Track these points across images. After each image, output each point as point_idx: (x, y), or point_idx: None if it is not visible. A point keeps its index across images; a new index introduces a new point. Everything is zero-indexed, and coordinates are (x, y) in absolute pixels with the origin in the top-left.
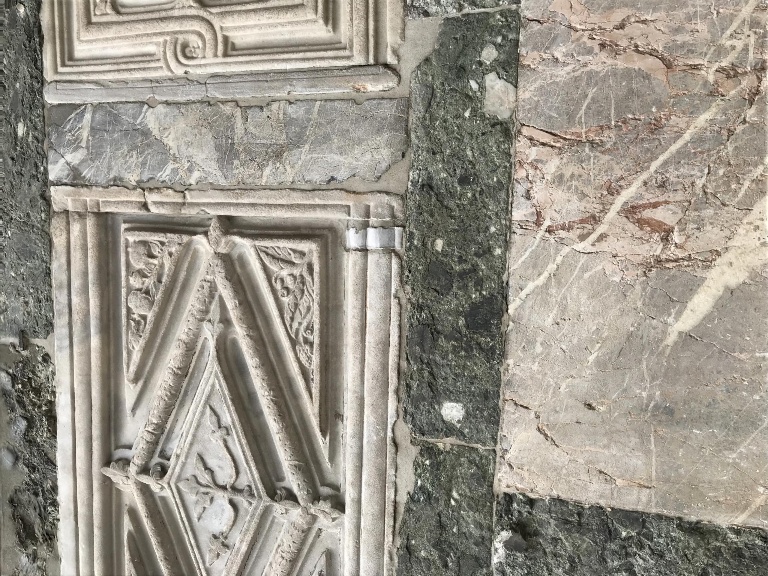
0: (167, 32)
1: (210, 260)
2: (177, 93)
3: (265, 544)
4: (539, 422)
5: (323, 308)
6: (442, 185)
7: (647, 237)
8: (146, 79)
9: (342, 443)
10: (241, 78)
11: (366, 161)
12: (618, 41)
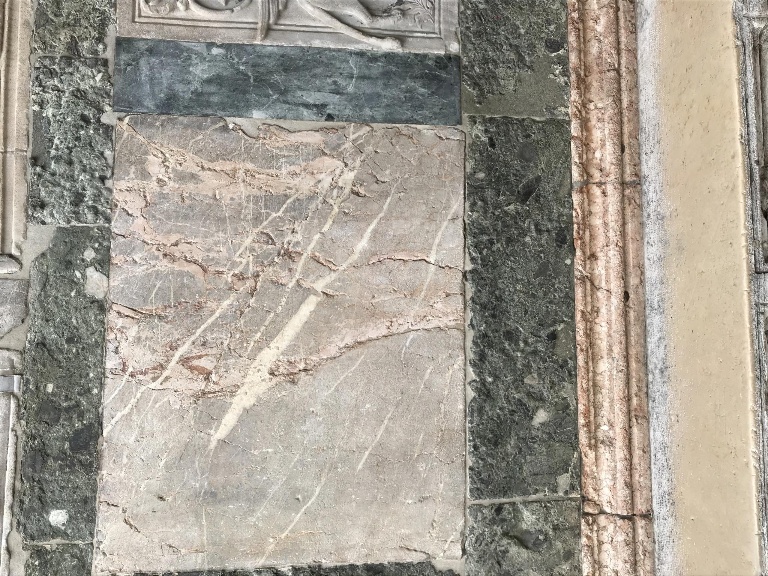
0: None
1: None
2: None
3: None
4: (126, 516)
5: None
6: (53, 344)
7: (196, 378)
8: None
9: None
10: None
11: None
12: (174, 253)
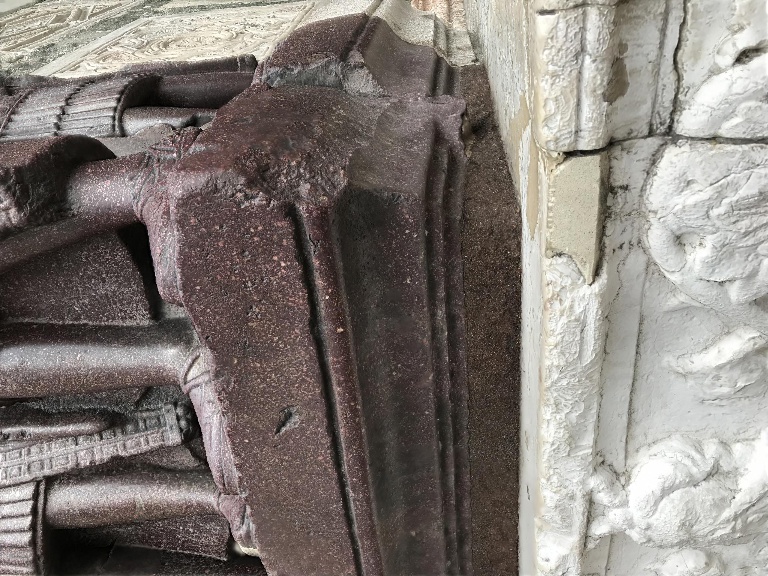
0: None
1: None
2: None
3: None
4: None
5: (111, 8)
6: None
7: None
8: None
9: None
10: None
11: None
12: None
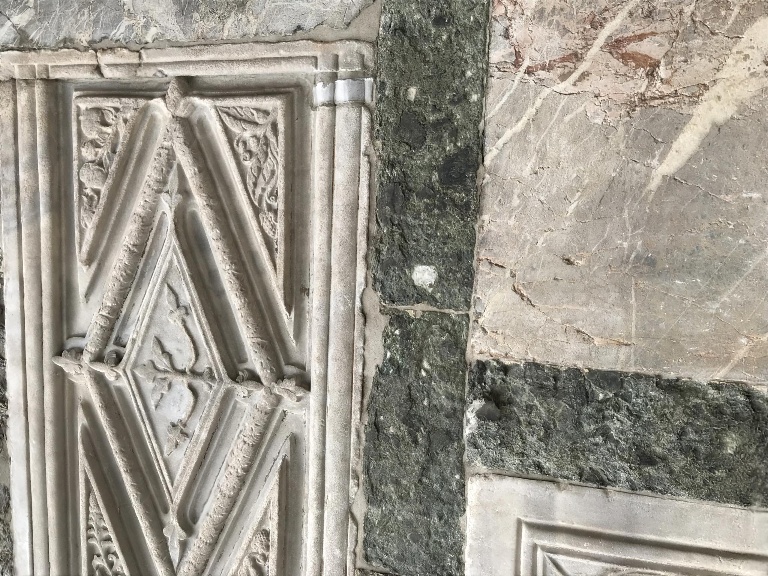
0: None
1: (168, 125)
2: None
3: (226, 432)
4: (515, 281)
5: (288, 172)
6: (415, 28)
7: (631, 73)
8: None
9: (308, 318)
10: None
11: (334, 7)
12: None
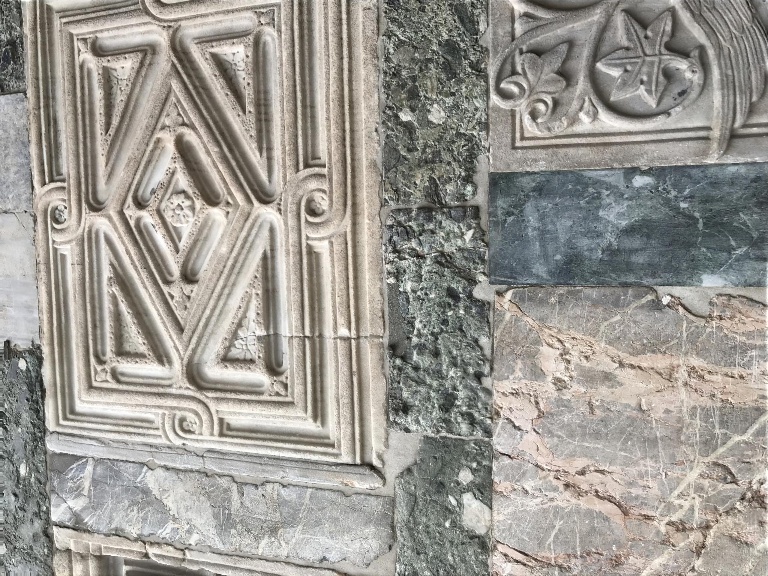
0: (165, 407)
1: None
2: (176, 460)
3: None
4: None
5: None
6: None
7: None
8: (146, 444)
9: None
10: (237, 457)
11: (356, 549)
12: (580, 485)
